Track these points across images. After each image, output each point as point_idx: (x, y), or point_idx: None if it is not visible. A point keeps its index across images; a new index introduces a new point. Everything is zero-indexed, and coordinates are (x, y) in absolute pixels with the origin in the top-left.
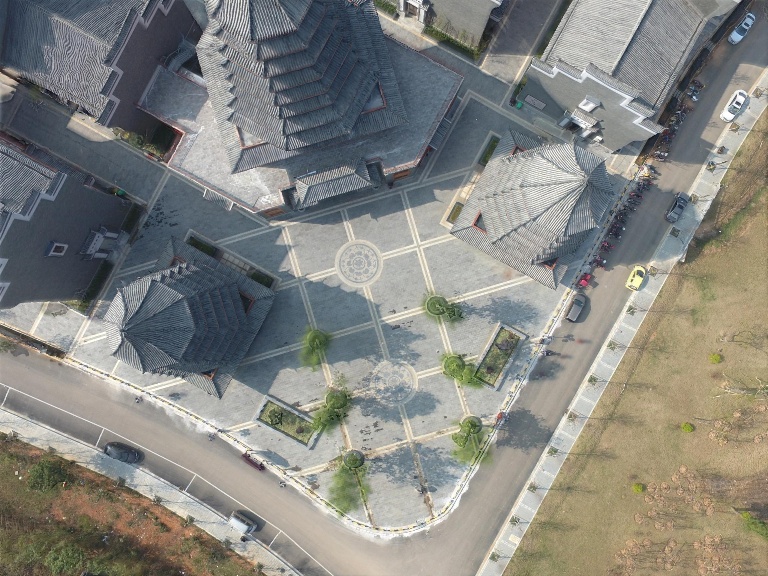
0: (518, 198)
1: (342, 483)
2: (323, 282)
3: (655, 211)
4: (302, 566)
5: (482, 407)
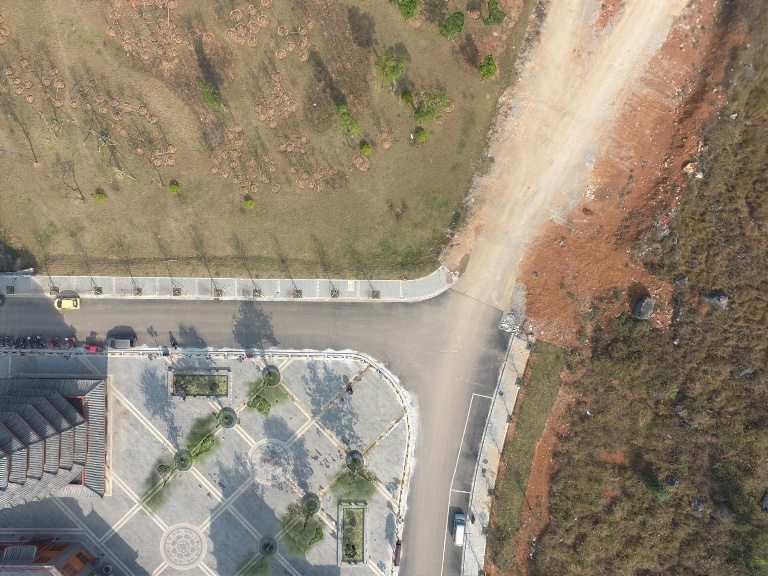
0: (2, 502)
1: (381, 460)
2: (216, 569)
3: (2, 316)
4: (472, 456)
5: (251, 375)
